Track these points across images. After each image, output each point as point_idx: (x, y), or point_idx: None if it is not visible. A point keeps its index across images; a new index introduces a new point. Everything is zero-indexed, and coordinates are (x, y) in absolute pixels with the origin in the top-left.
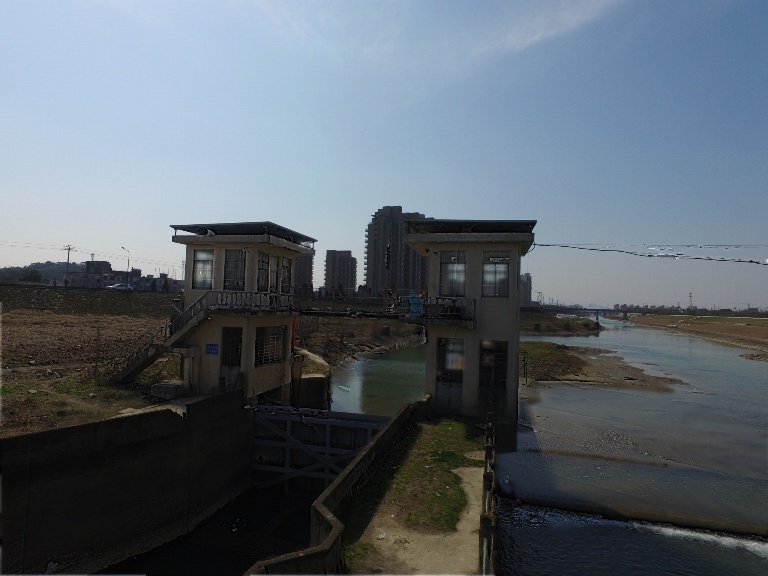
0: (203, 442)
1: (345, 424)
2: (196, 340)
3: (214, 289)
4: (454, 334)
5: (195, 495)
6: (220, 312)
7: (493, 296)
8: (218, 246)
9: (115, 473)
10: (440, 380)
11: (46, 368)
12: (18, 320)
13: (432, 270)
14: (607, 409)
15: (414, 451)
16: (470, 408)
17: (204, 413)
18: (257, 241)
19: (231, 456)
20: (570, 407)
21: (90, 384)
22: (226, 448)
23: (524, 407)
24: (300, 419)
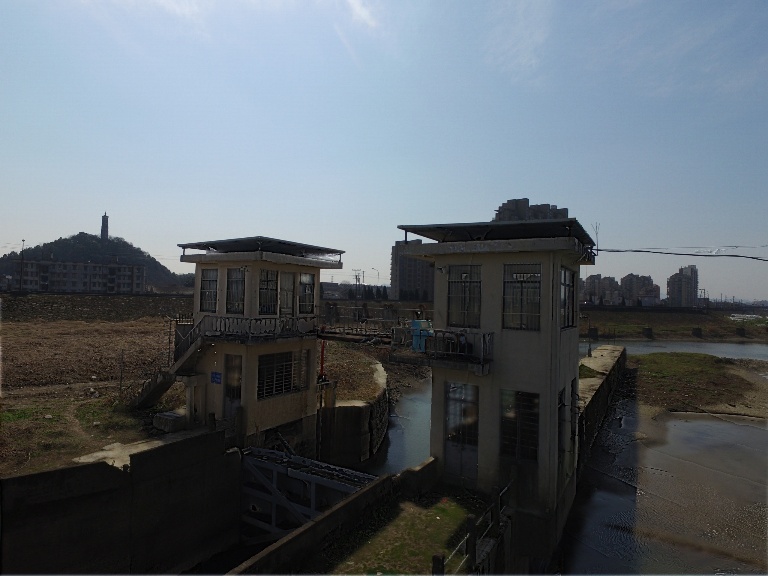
0: (155, 497)
1: (330, 484)
2: (203, 367)
3: (218, 312)
4: (466, 379)
5: (143, 559)
6: (214, 339)
7: (518, 328)
8: (221, 265)
9: (28, 536)
10: (450, 439)
11: (100, 385)
12: (132, 329)
13: (438, 291)
14: (767, 464)
15: (347, 564)
16: (487, 483)
17: (157, 463)
18: (251, 259)
19: (204, 509)
20: (707, 456)
21: (110, 408)
22: (195, 501)
23: (636, 452)
24: (286, 471)
